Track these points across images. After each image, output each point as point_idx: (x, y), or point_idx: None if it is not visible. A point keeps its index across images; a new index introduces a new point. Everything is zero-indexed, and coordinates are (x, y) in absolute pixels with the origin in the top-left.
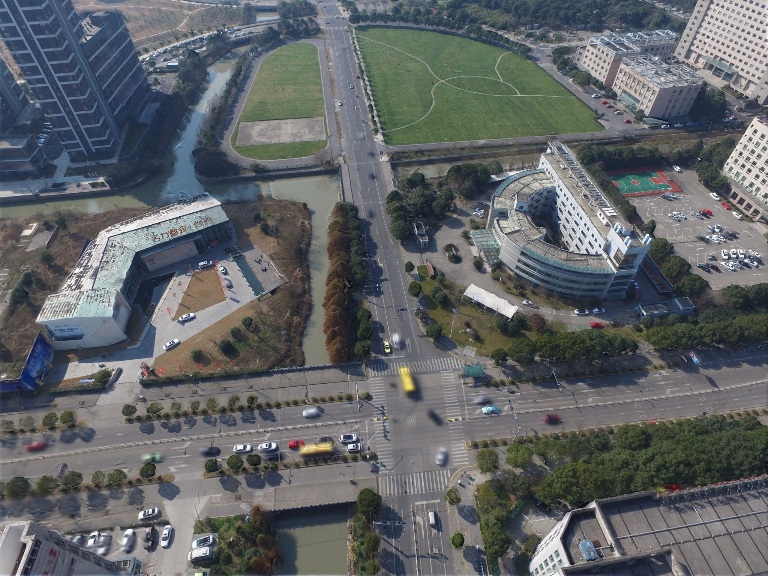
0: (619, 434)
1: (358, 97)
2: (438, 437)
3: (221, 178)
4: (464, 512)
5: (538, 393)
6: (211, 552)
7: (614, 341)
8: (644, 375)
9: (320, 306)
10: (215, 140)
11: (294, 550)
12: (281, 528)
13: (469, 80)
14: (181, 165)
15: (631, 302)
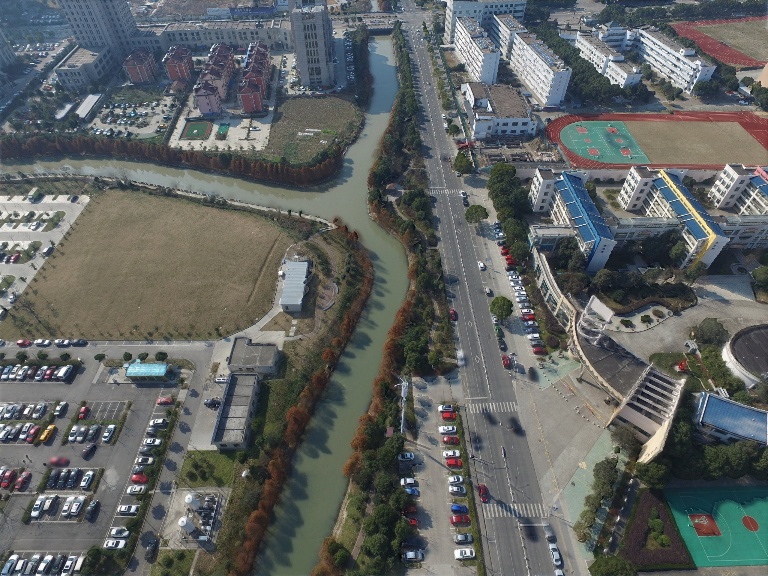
0: None
1: None
2: None
3: None
4: (428, 30)
5: None
6: None
7: None
8: None
9: (376, 2)
10: None
11: (374, 38)
12: None
13: None
14: None
15: None
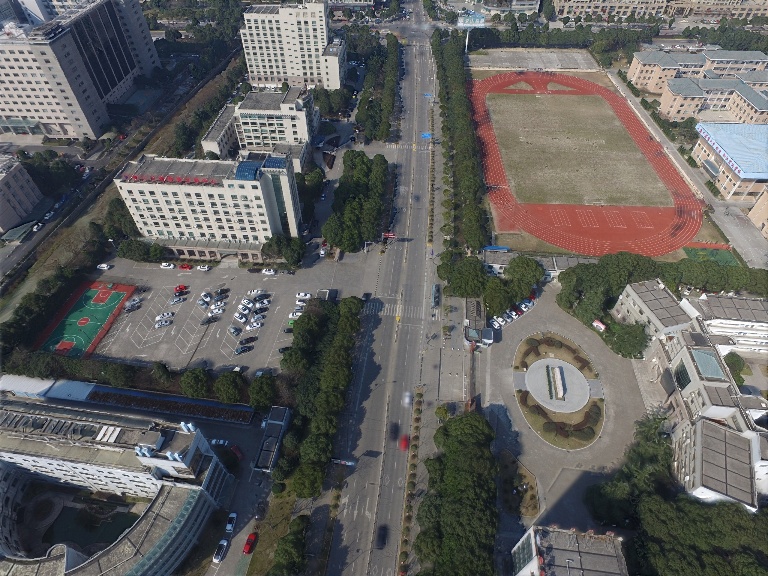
0: None
1: None
2: None
3: None
4: None
5: None
6: None
7: (292, 559)
8: (339, 529)
9: None
10: None
11: None
12: None
13: None
14: None
15: (241, 467)
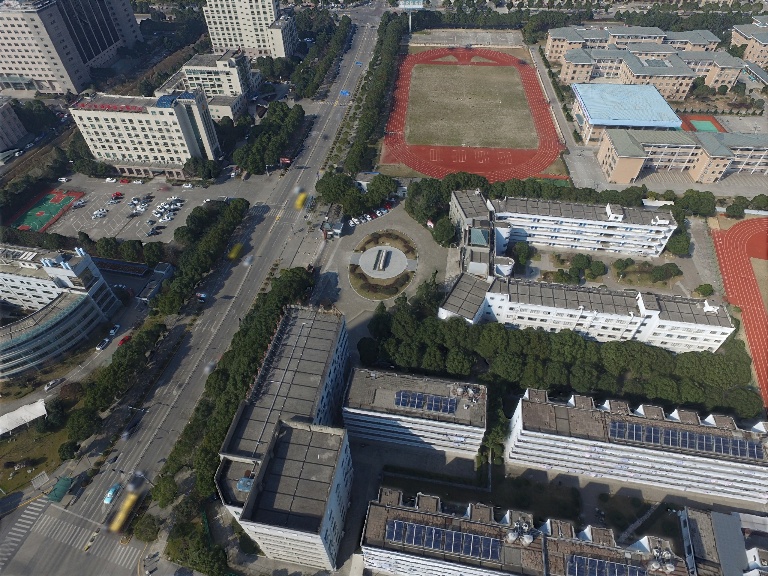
0: (208, 391)
1: None
2: (92, 574)
3: None
4: None
5: (135, 434)
6: None
7: (142, 340)
8: (189, 337)
9: None
10: None
11: None
12: None
13: None
14: None
15: (131, 301)
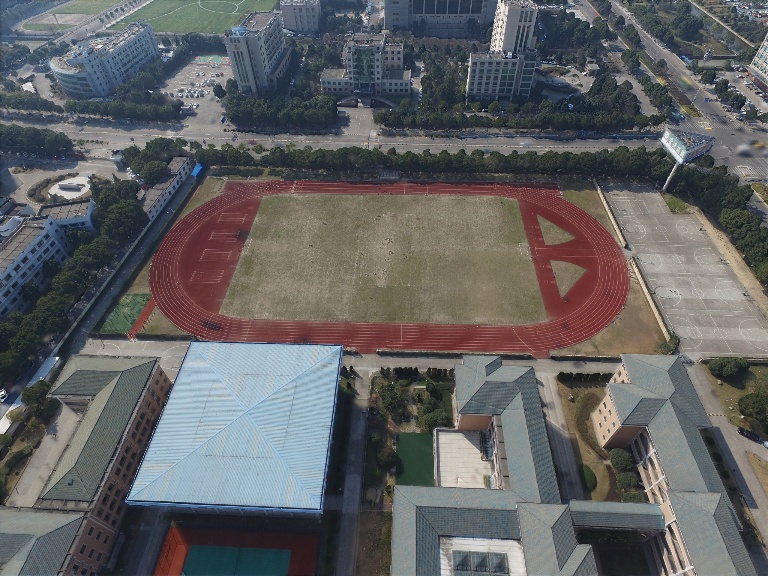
0: None
1: (133, 7)
2: None
3: None
4: None
5: None
6: None
7: None
8: None
9: None
10: (20, 20)
11: None
12: None
13: (217, 3)
14: None
15: None
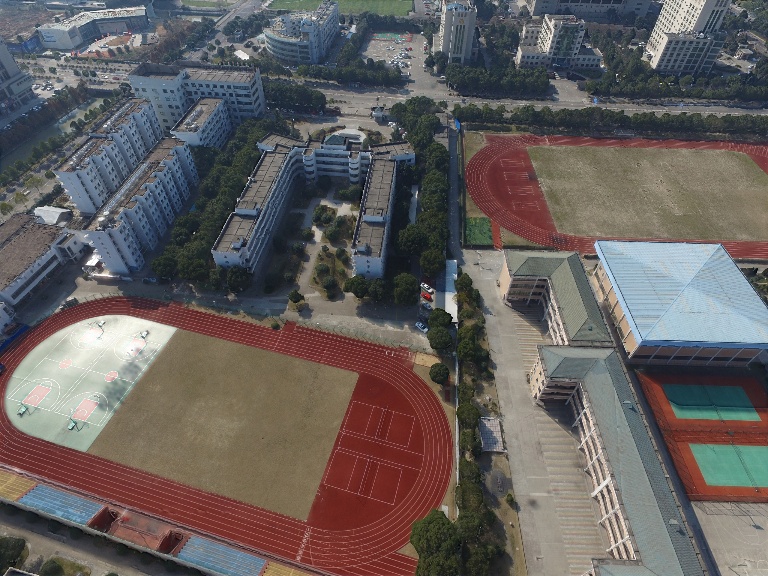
0: None
1: None
2: None
3: (164, 10)
4: None
5: None
6: (61, 90)
7: (274, 65)
8: None
9: None
10: None
11: None
12: (94, 97)
13: None
14: (150, 5)
15: None
